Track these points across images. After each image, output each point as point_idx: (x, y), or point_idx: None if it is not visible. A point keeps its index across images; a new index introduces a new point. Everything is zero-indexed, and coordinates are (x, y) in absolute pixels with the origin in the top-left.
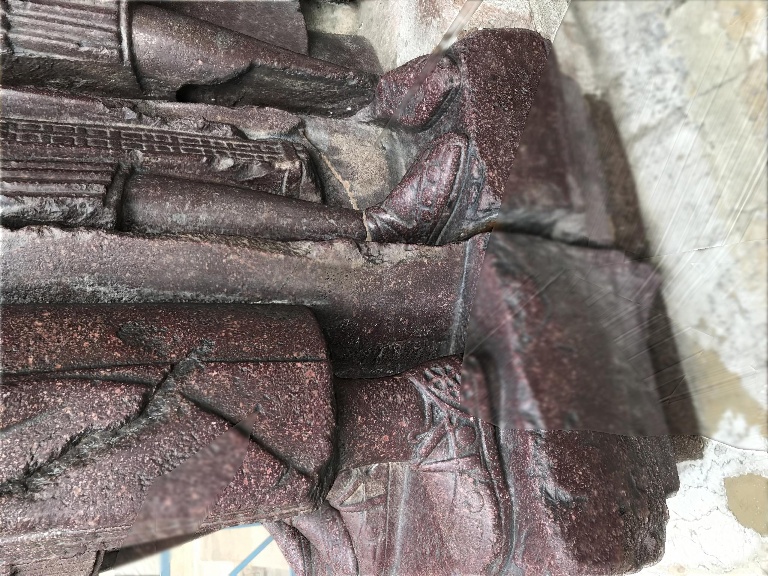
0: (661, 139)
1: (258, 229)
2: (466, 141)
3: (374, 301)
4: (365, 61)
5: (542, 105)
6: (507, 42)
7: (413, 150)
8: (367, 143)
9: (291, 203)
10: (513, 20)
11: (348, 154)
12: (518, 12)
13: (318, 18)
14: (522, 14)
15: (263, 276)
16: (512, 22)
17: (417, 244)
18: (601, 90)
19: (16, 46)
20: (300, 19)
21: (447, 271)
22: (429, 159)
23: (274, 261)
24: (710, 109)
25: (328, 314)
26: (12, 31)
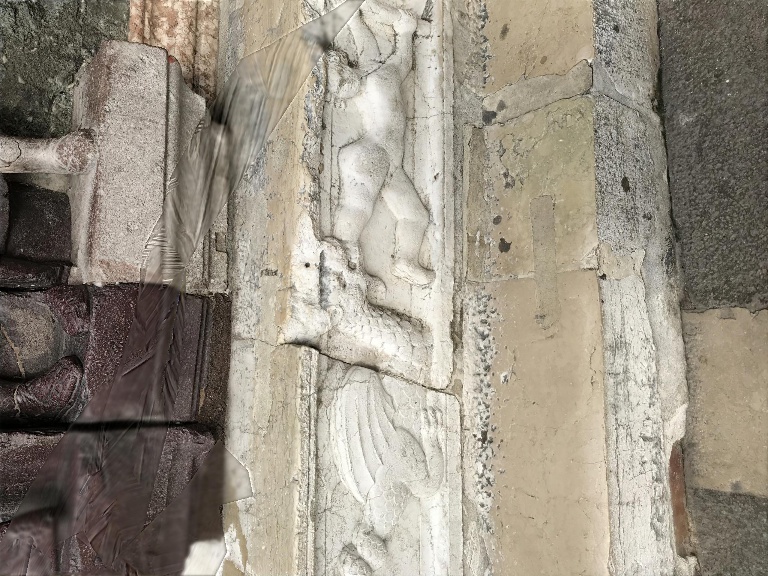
0: (42, 563)
1: None
2: (81, 375)
3: (2, 466)
4: (59, 237)
5: (31, 494)
6: (132, 298)
7: (69, 336)
8: (41, 317)
9: None
10: None
11: (23, 326)
12: None
13: (35, 175)
14: None
15: None
16: None
17: (37, 435)
18: (49, 506)
19: None
20: (5, 205)
21: None
22: (58, 377)
23: None
24: (50, 568)
25: None
26: None
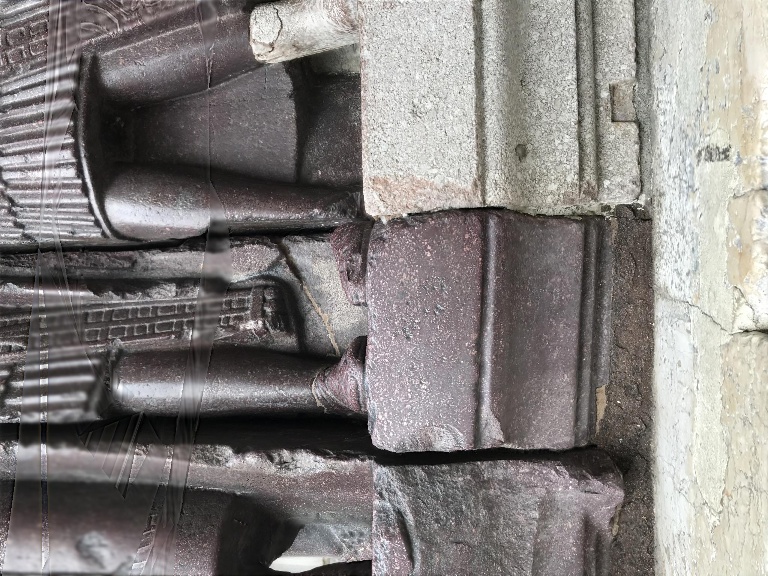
0: None
1: (216, 404)
2: (361, 375)
3: (295, 492)
4: None
5: None
6: (428, 241)
7: None
8: None
9: (245, 375)
10: (448, 198)
11: (329, 283)
12: (457, 184)
13: (342, 57)
14: (462, 186)
15: (196, 476)
16: (446, 201)
17: (325, 457)
18: None
19: (35, 236)
20: (291, 110)
21: (358, 478)
22: (339, 373)
23: (200, 469)
24: None
25: (258, 498)
26: (27, 228)
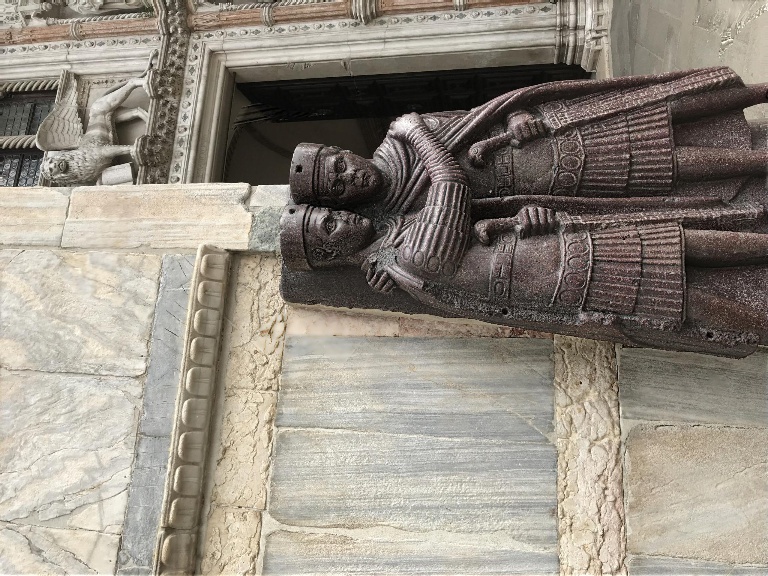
0: None
1: None
2: None
3: None
4: None
5: None
6: None
7: None
8: None
9: None
10: None
11: None
12: None
13: None
14: None
15: None
16: None
17: None
18: None
19: None
20: None
21: None
22: None
23: None
24: None
25: None
26: None
